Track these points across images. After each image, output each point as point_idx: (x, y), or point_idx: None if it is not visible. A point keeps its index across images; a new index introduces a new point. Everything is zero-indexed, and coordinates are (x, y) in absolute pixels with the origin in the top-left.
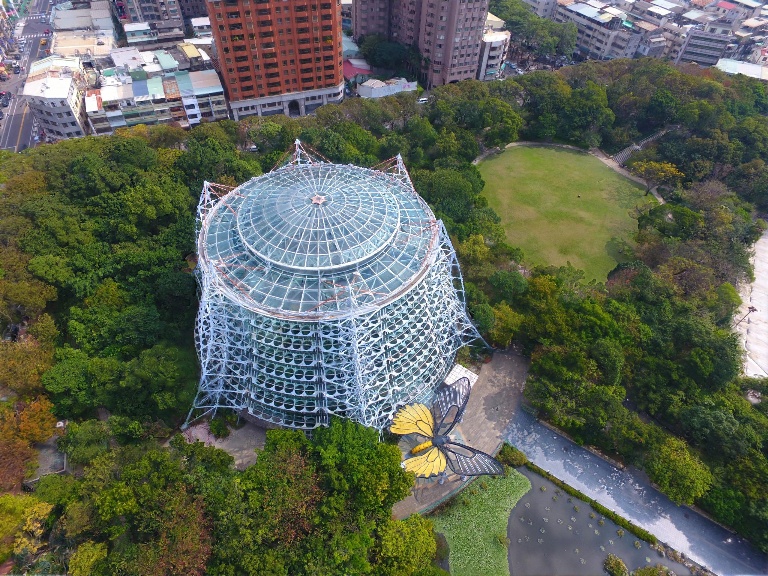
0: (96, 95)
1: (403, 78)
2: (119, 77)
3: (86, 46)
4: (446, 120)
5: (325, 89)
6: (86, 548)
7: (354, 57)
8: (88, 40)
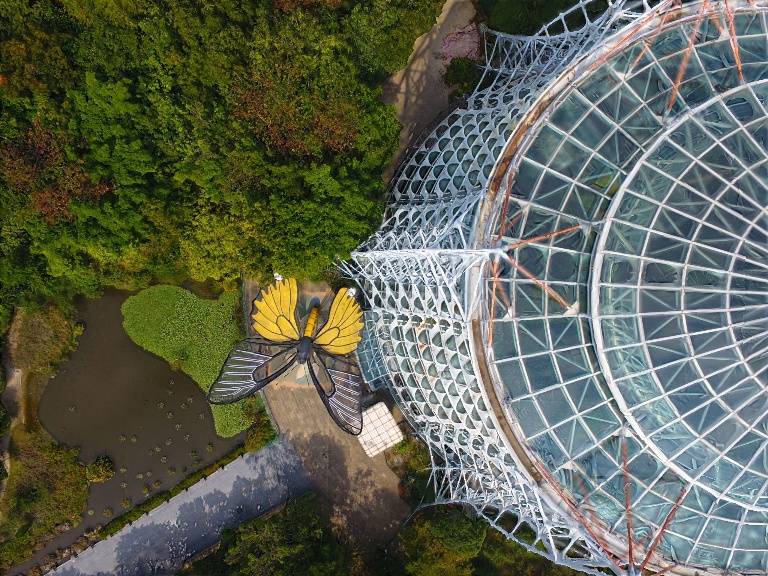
0: None
1: None
2: None
3: None
4: None
5: None
6: None
7: None
8: None
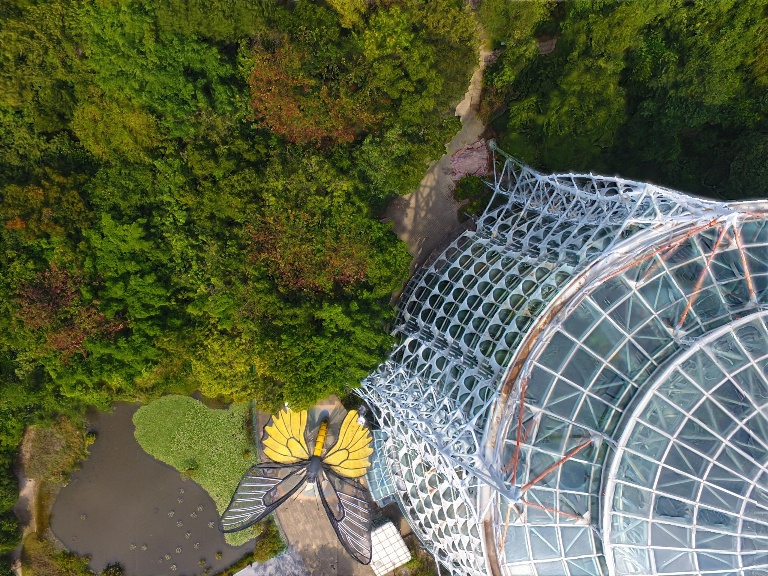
0: None
1: None
2: None
3: None
4: None
5: None
6: (355, 1)
7: None
8: None
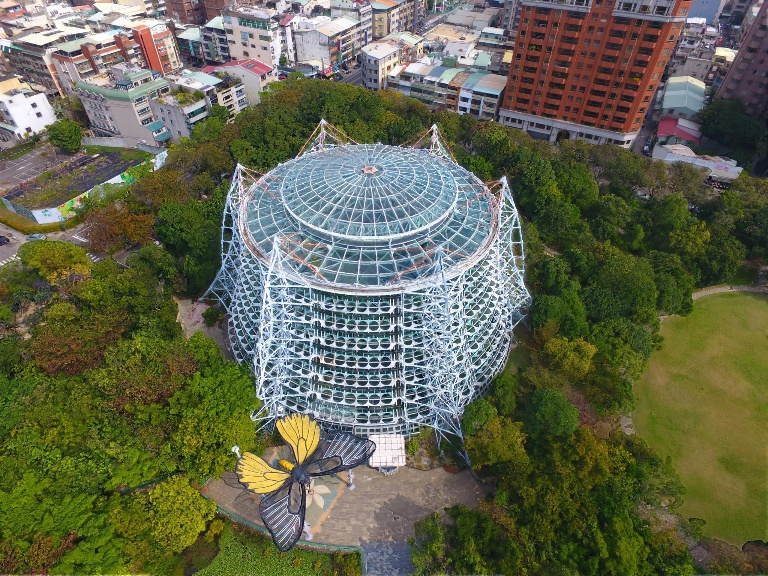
0: (405, 66)
1: (734, 160)
2: (434, 59)
3: (451, 37)
4: (721, 217)
5: (607, 131)
6: (66, 305)
7: (689, 118)
8: (458, 34)
